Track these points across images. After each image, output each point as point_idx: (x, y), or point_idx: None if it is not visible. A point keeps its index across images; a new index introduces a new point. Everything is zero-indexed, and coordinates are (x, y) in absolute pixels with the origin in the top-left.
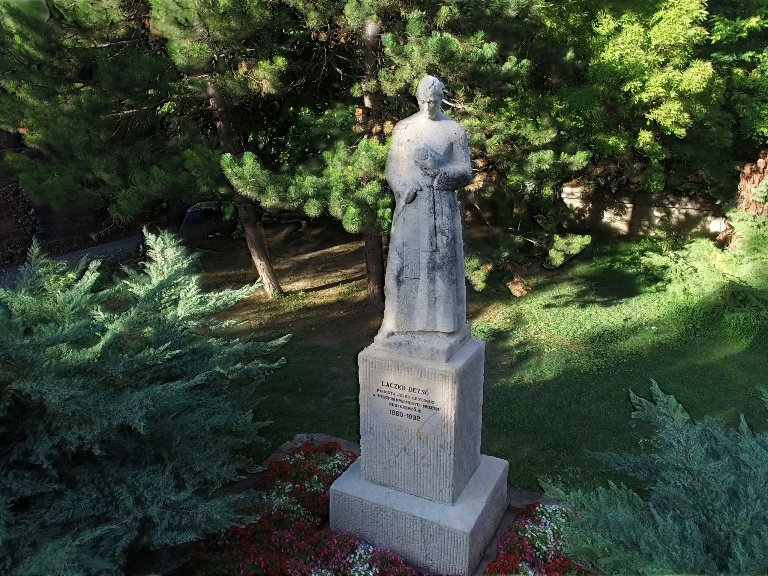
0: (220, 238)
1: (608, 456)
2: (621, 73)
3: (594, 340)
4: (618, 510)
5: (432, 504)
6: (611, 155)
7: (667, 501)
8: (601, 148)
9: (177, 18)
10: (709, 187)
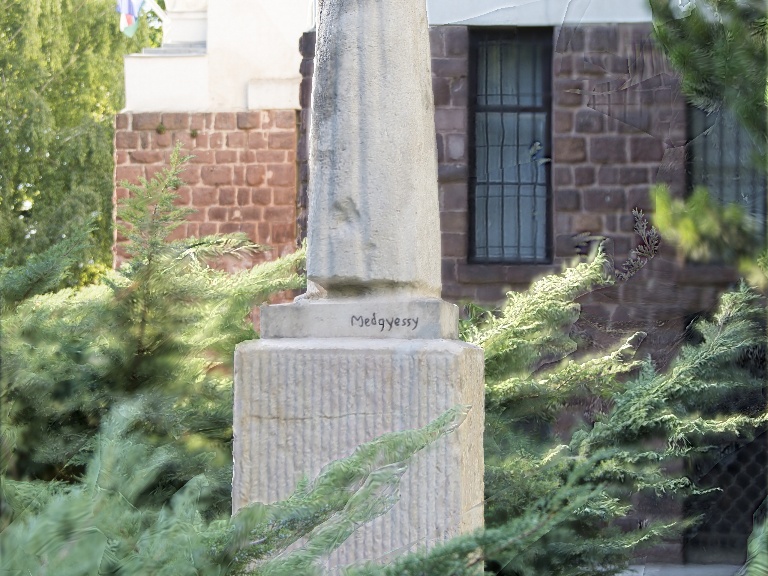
0: None
1: None
2: None
3: None
4: None
5: None
6: None
7: None
8: None
9: None
10: None
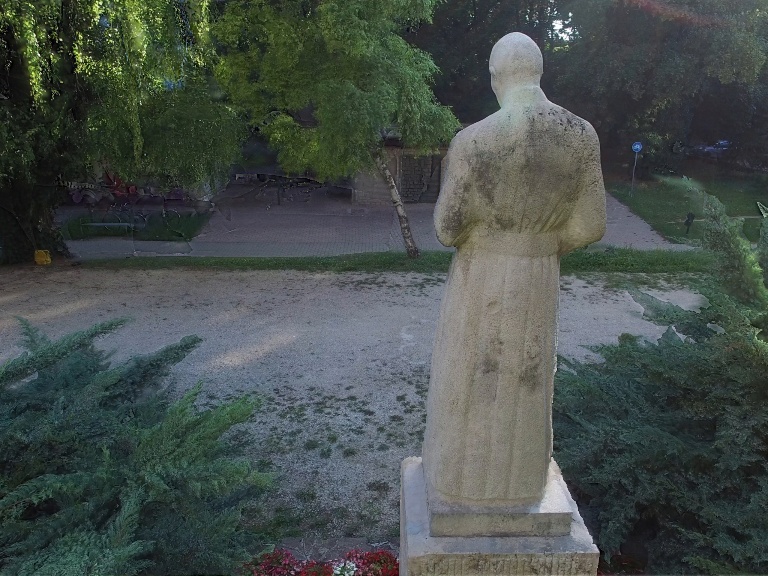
0: None
1: None
2: None
3: None
4: None
5: None
6: None
7: None
8: None
9: None
10: None
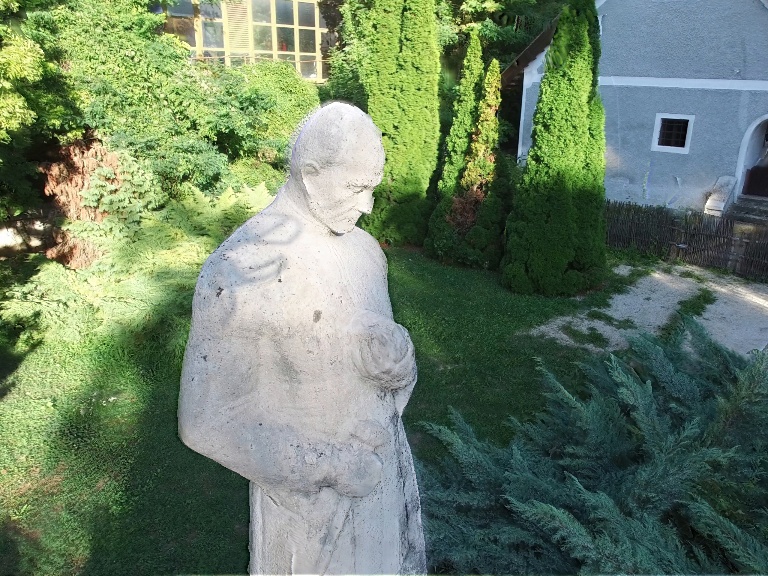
0: None
1: None
2: None
3: (55, 458)
4: None
5: None
6: None
7: None
8: None
9: None
10: None
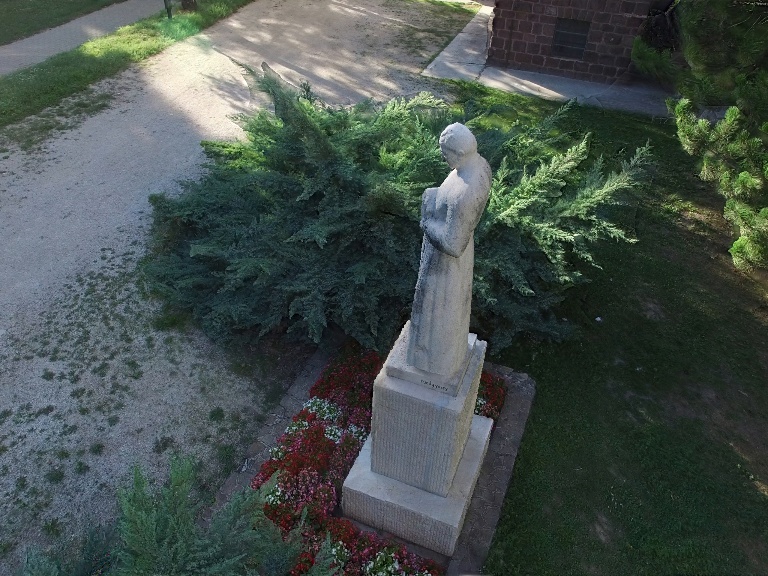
0: None
1: None
2: None
3: None
4: None
5: None
6: None
7: None
8: None
9: None
10: None
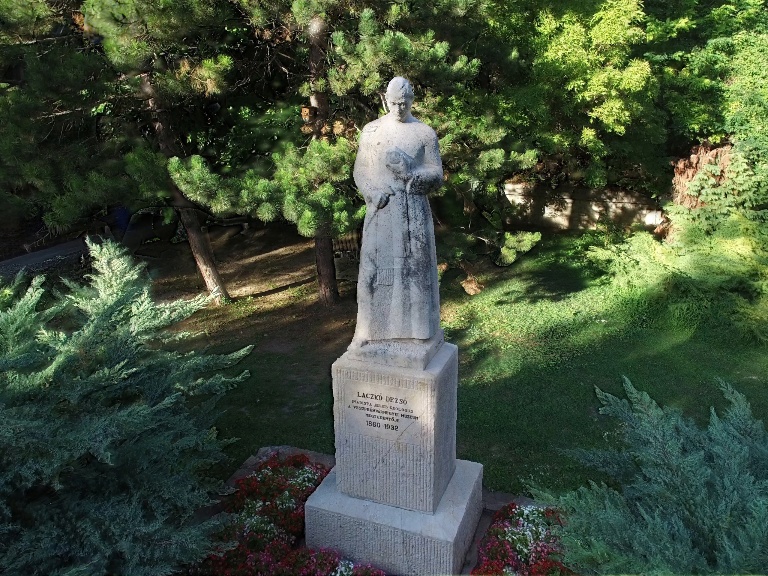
0: (158, 243)
1: (578, 452)
2: (565, 72)
3: (547, 335)
4: (607, 511)
5: (412, 514)
6: (556, 152)
7: (649, 497)
8: (547, 146)
9: (113, 14)
10: (645, 182)
